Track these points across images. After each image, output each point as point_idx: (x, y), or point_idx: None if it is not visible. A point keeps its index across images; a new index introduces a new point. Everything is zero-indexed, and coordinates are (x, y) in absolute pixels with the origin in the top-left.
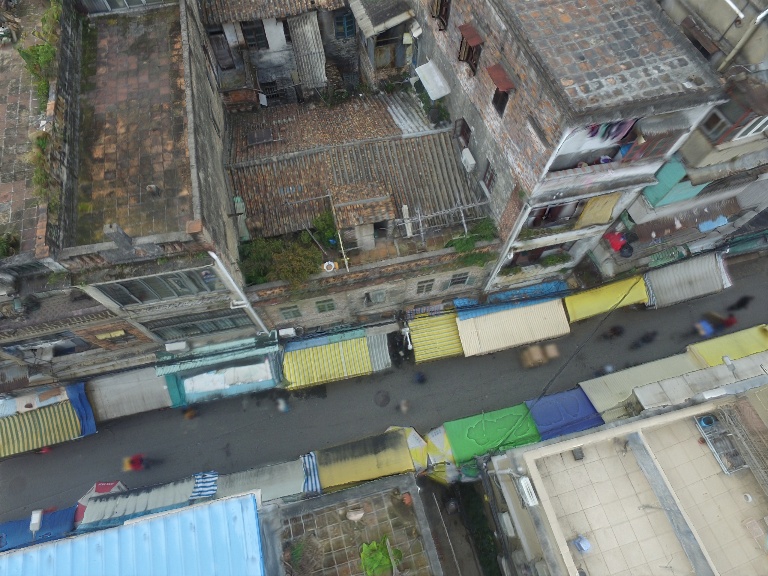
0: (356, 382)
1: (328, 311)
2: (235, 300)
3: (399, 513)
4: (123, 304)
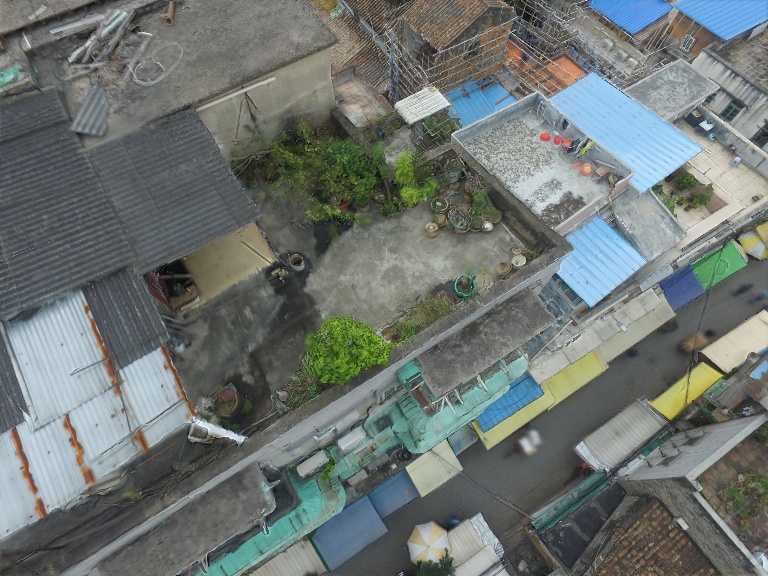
0: None
1: None
2: None
3: None
4: None
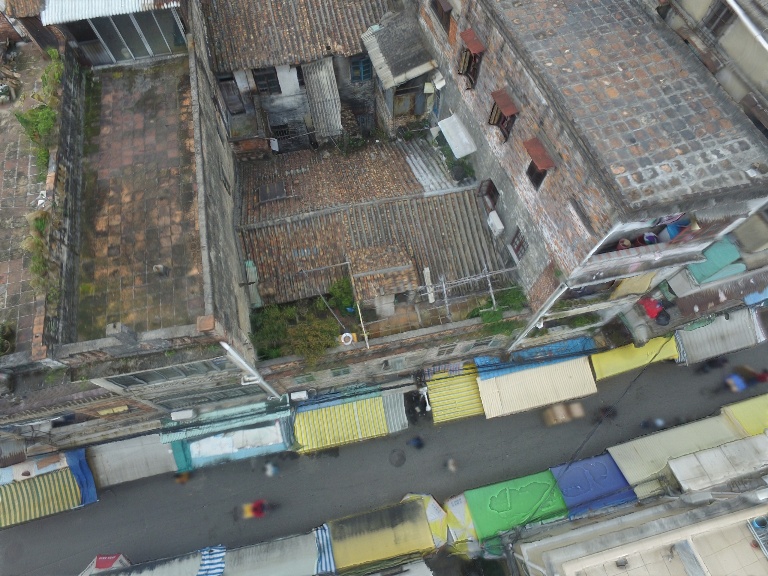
0: (370, 439)
1: (343, 374)
2: (246, 376)
3: None
4: (127, 385)
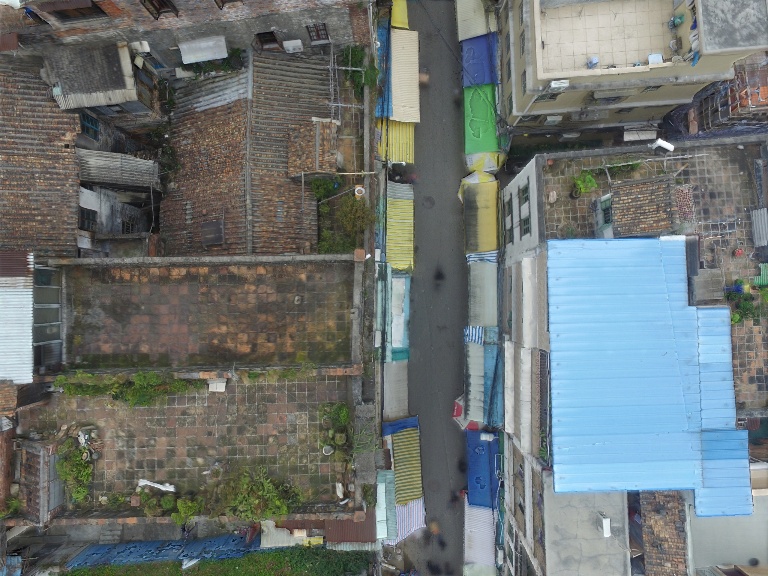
0: None
1: None
2: None
3: (557, 170)
4: None
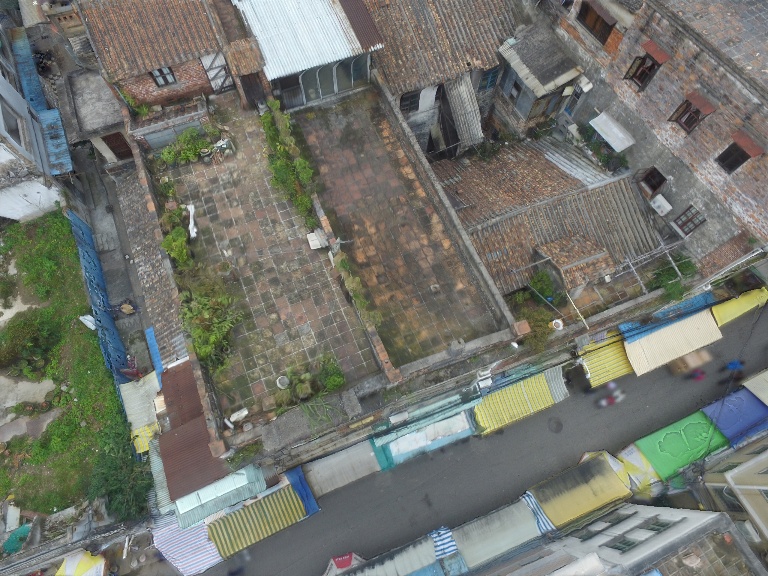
0: None
1: None
2: (481, 371)
3: (724, 551)
4: None
